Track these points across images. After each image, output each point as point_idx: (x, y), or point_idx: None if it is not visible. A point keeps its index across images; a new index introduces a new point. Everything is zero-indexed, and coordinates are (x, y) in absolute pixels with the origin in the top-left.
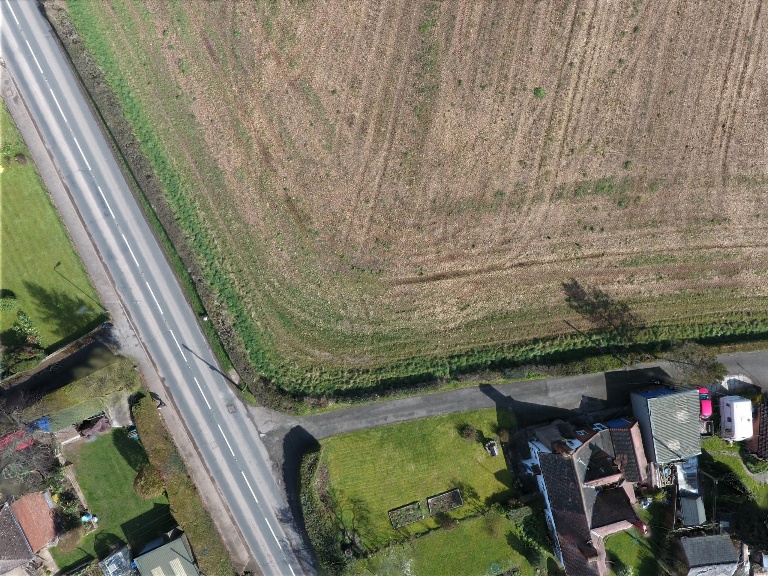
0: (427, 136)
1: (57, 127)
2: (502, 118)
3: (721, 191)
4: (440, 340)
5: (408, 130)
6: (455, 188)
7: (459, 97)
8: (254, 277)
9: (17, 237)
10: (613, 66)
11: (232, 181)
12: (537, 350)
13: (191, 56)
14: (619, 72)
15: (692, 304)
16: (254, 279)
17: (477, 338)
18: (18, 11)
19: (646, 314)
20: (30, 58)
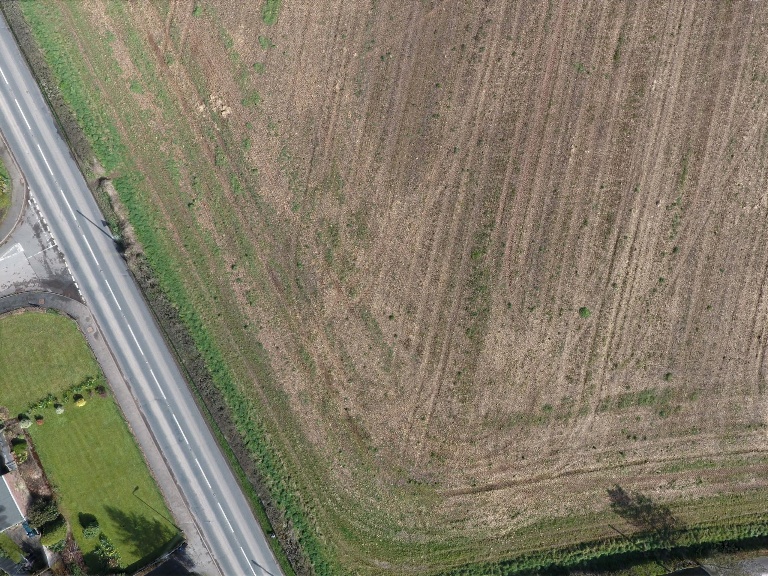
0: (479, 356)
1: (134, 360)
2: (549, 337)
3: (757, 398)
4: (492, 547)
5: (461, 351)
6: (505, 404)
7: (509, 319)
8: (318, 493)
9: (98, 464)
10: (654, 285)
11: (297, 403)
12: (584, 555)
13: (258, 287)
14: (659, 290)
15: (731, 506)
16: (318, 495)
17: (527, 544)
18: (98, 253)
19: (687, 517)
20: (109, 296)
